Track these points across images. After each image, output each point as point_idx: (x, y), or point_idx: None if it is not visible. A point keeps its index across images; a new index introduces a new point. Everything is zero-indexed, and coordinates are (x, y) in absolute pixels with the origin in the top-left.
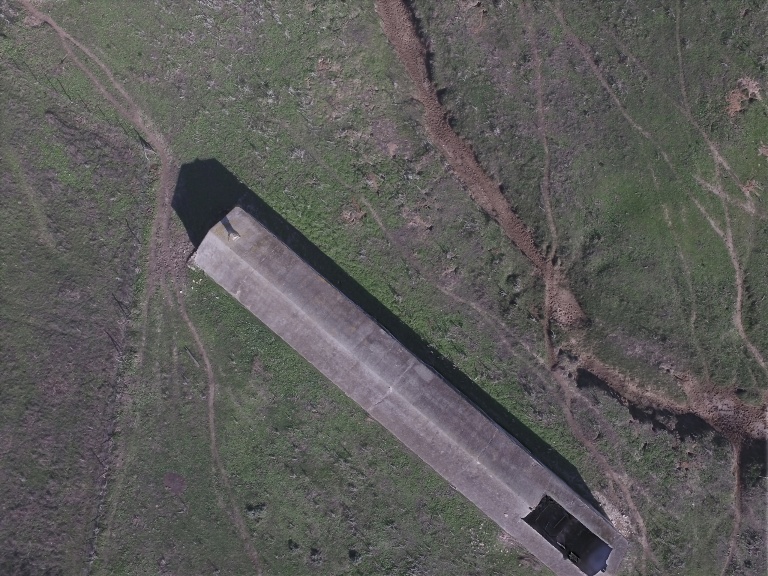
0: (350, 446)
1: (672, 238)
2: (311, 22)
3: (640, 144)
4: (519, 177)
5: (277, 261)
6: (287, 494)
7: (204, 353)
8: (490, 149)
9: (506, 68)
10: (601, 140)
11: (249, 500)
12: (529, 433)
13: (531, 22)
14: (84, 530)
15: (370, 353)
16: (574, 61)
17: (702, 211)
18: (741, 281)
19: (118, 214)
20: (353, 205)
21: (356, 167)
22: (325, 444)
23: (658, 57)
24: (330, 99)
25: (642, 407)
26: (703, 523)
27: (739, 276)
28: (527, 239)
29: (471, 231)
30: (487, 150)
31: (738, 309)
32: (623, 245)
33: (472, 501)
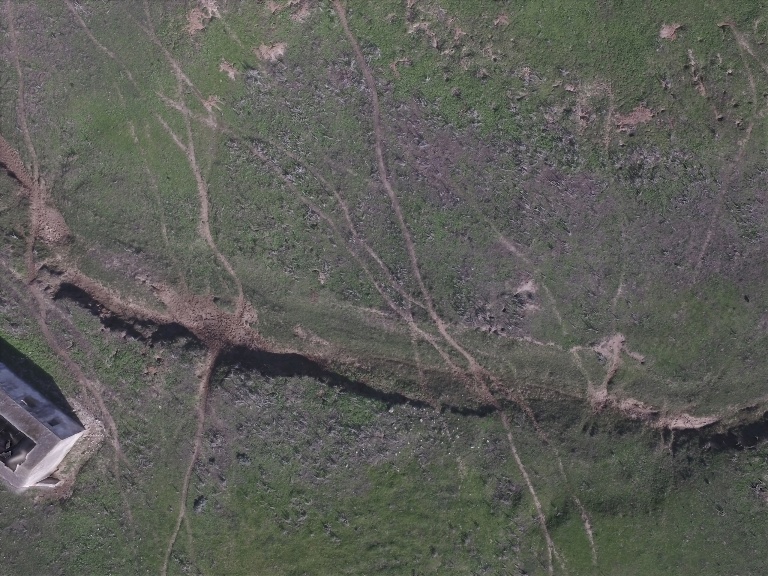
0: None
1: (139, 153)
2: None
3: (105, 63)
4: None
5: None
6: None
7: None
8: None
9: None
10: (70, 61)
11: None
12: (5, 344)
13: None
14: None
15: None
16: None
17: (165, 126)
18: (206, 192)
19: None
20: None
21: None
22: None
23: None
24: None
25: (126, 318)
26: (169, 424)
27: (203, 188)
28: (18, 161)
29: None
30: None
31: (206, 220)
32: (94, 162)
33: None
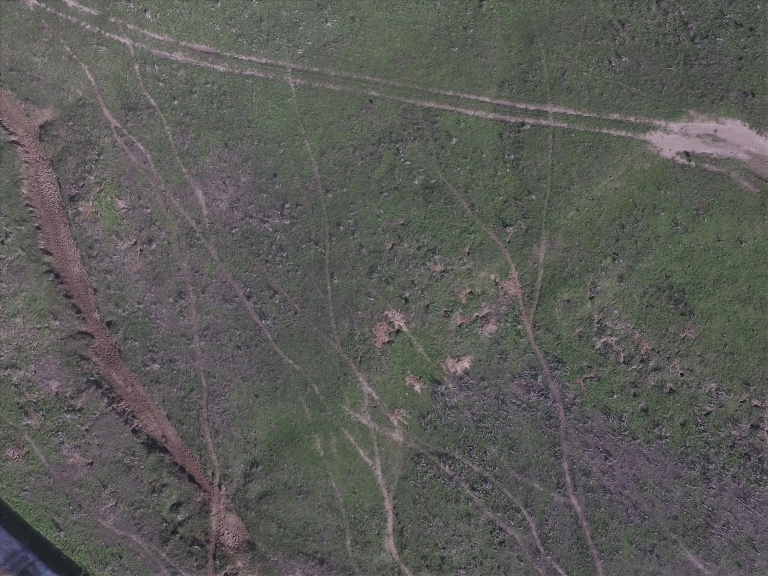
0: None
1: (324, 467)
2: None
3: (292, 377)
4: (181, 408)
5: None
6: None
7: None
8: (152, 382)
9: (163, 304)
10: (255, 373)
11: None
12: None
13: (186, 260)
14: None
15: None
16: (227, 297)
17: (352, 441)
18: (391, 507)
19: None
20: (16, 442)
21: (20, 404)
22: None
23: (309, 291)
24: None
25: None
26: None
27: (389, 502)
28: (197, 463)
29: (131, 465)
30: (150, 382)
31: (391, 533)
32: (279, 474)
33: None
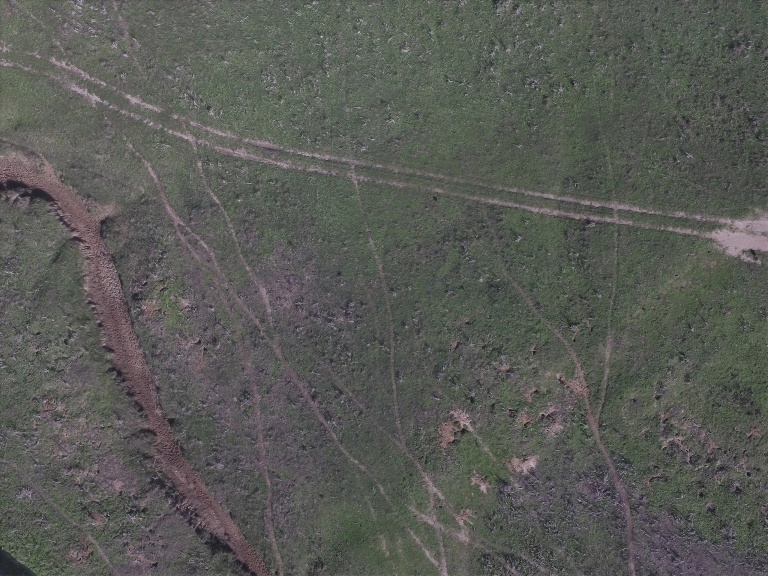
0: None
1: (390, 568)
2: (36, 363)
3: (357, 477)
4: (245, 507)
5: None
6: None
7: None
8: (216, 481)
9: (227, 404)
10: (320, 473)
11: None
12: None
13: (250, 359)
14: None
15: None
16: (292, 397)
17: (418, 542)
18: None
19: None
20: (80, 543)
21: (83, 505)
22: None
23: (373, 391)
24: (56, 438)
25: None
26: None
27: None
28: (259, 561)
29: (196, 566)
30: (213, 481)
31: None
32: (344, 575)
33: None
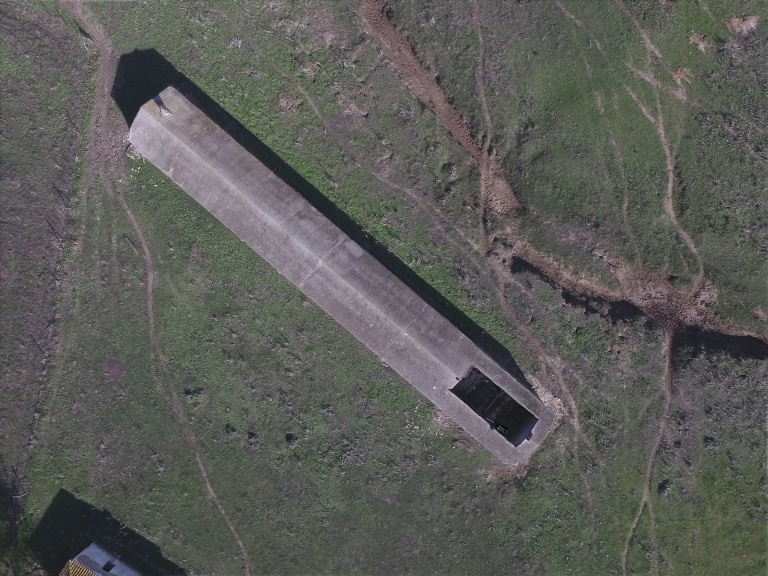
0: (287, 332)
1: (604, 125)
2: None
3: (573, 32)
4: (455, 67)
5: (209, 138)
6: (225, 379)
7: (143, 241)
8: (426, 39)
9: None
10: (535, 29)
11: (187, 385)
12: (463, 317)
13: None
14: (24, 416)
15: (300, 228)
16: None
17: (634, 98)
18: (672, 167)
19: (58, 104)
20: (290, 93)
21: (293, 56)
22: (262, 330)
23: None
24: None
25: (576, 294)
26: (634, 404)
27: (670, 162)
28: (464, 130)
29: (406, 119)
30: (423, 40)
31: (670, 195)
32: (556, 132)
33: (402, 376)
